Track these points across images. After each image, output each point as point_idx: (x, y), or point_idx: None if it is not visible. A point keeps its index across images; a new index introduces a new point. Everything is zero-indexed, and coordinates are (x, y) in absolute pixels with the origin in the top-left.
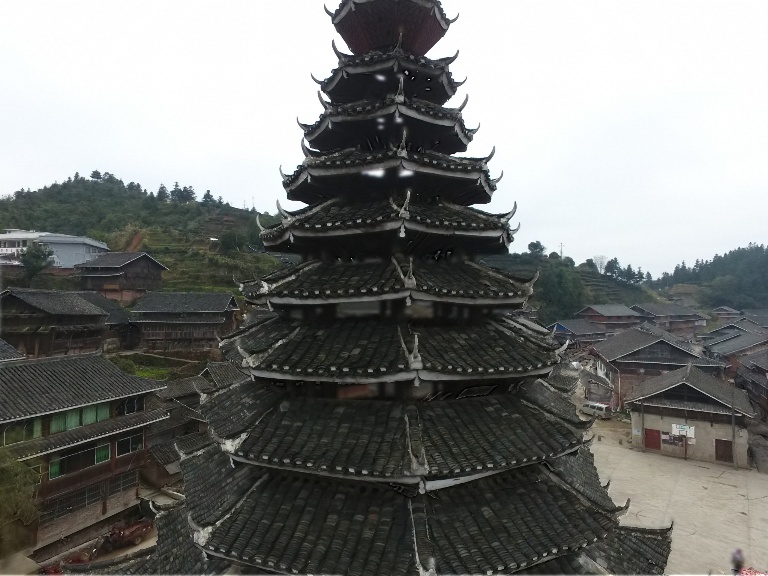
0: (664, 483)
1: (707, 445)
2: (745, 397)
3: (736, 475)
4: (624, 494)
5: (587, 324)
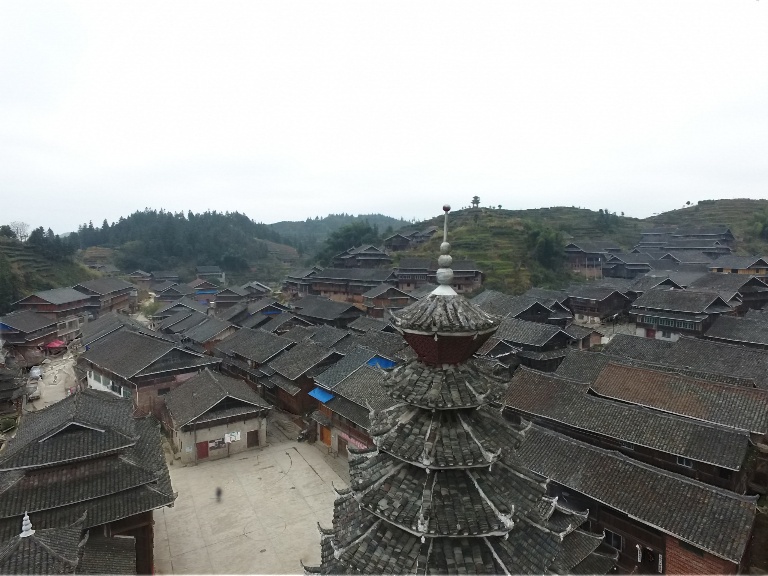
0: (235, 490)
1: (242, 439)
2: (249, 388)
3: (265, 455)
4: (221, 520)
5: (33, 316)
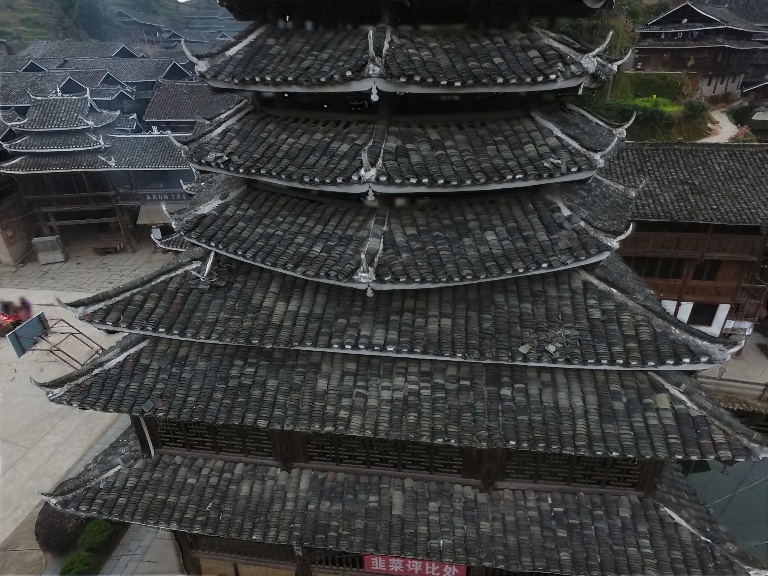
0: None
1: None
2: None
3: None
4: None
5: None
